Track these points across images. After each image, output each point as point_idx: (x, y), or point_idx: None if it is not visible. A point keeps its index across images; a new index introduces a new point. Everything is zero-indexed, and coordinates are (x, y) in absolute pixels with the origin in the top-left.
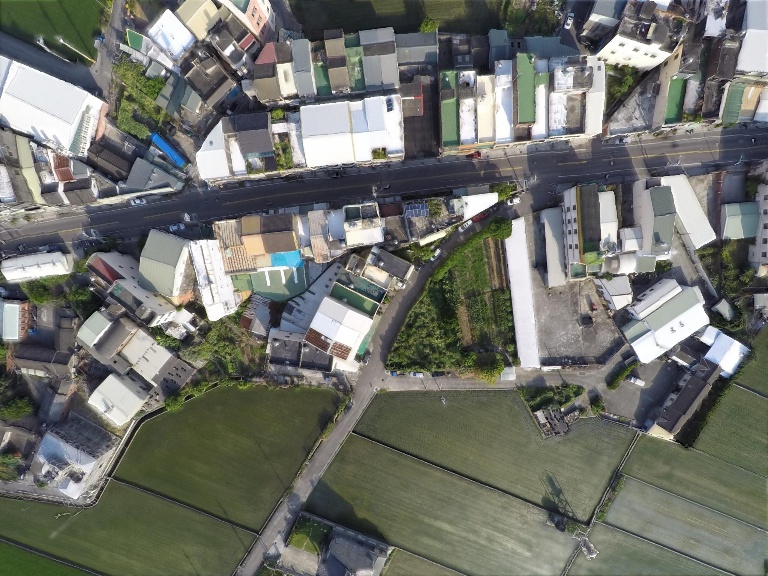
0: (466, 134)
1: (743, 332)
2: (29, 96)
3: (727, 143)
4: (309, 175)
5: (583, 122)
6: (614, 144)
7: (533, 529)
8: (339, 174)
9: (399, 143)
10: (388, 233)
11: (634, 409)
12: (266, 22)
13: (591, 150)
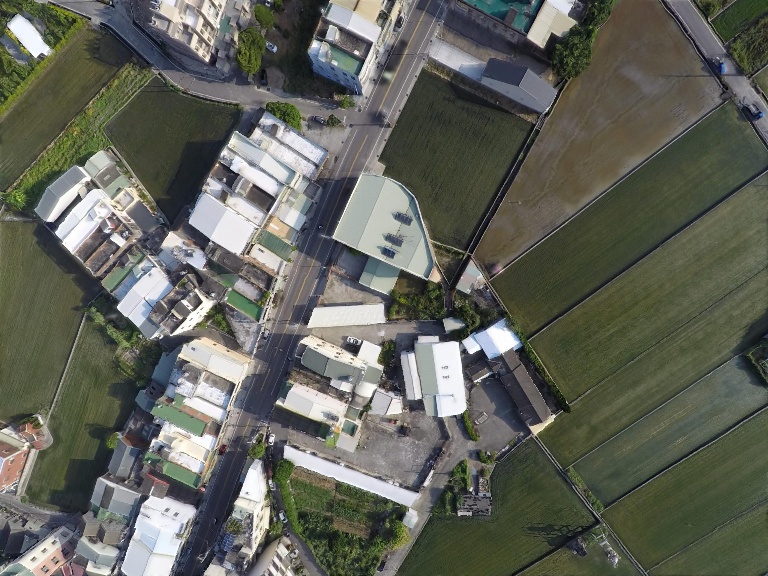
0: (196, 466)
1: (485, 315)
2: None
3: (311, 250)
4: (181, 567)
5: (227, 380)
6: (266, 342)
7: (573, 567)
8: (189, 548)
9: (176, 523)
10: (237, 565)
11: (509, 429)
12: (62, 547)
13: (262, 361)
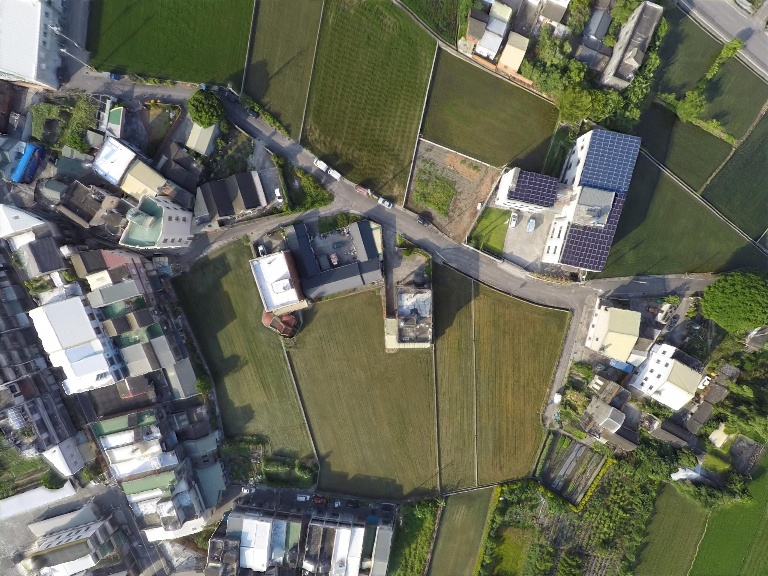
0: (113, 439)
1: None
2: (5, 15)
3: None
4: None
5: (150, 527)
6: None
7: None
8: None
9: (75, 389)
10: None
11: None
12: None
13: None
